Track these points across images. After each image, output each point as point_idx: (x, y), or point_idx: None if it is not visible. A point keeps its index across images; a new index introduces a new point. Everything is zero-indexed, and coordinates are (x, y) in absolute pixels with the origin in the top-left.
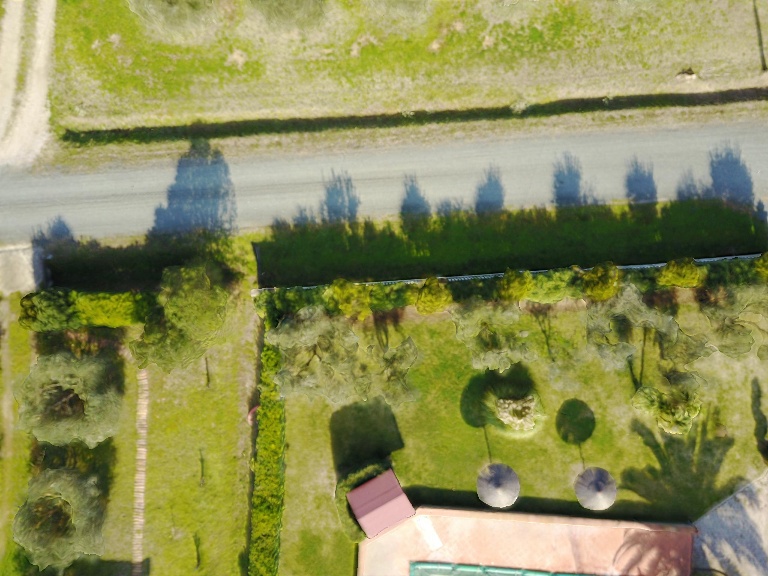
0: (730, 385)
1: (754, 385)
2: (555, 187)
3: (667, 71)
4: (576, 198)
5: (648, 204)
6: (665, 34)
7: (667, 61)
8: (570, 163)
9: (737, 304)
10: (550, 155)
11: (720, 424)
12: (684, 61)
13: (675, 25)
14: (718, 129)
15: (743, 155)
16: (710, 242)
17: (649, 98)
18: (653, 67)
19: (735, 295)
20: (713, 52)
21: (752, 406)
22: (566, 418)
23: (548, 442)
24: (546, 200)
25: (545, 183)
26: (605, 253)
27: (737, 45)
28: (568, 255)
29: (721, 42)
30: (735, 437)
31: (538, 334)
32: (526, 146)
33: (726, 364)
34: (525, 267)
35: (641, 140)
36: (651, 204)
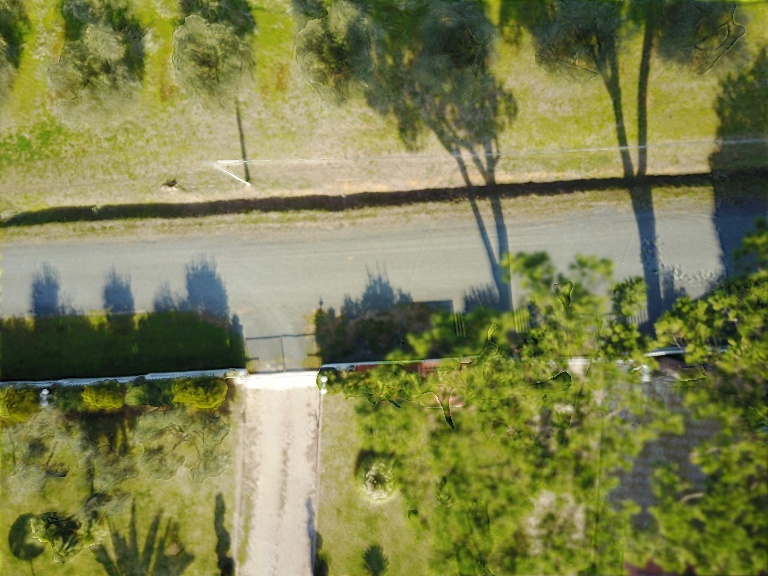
0: (193, 501)
1: (219, 501)
2: (34, 297)
3: (153, 182)
4: (54, 308)
5: (126, 315)
6: (151, 145)
7: (153, 172)
8: (49, 273)
9: (140, 431)
10: (30, 264)
11: (176, 542)
12: (169, 172)
13: (161, 136)
14: (196, 242)
15: (219, 268)
16: (185, 355)
17: (140, 207)
18: (139, 177)
19: (138, 422)
20: (198, 164)
21: (215, 523)
22: (19, 533)
23: (1, 557)
24: (25, 309)
25: (24, 292)
26: (81, 364)
27: (221, 157)
28: (44, 365)
29: (205, 154)
30: (195, 554)
31: (6, 445)
32: (6, 255)
33: (190, 480)
34: (1, 376)
35: (119, 251)
36: (129, 315)
